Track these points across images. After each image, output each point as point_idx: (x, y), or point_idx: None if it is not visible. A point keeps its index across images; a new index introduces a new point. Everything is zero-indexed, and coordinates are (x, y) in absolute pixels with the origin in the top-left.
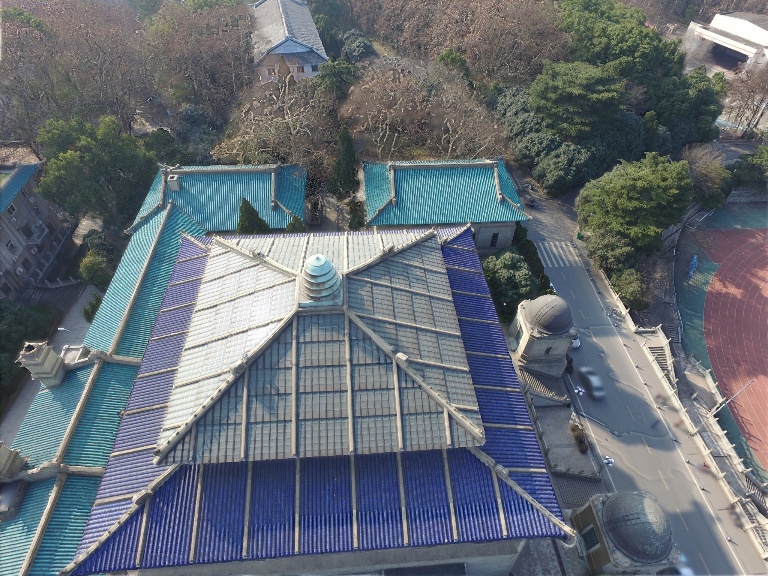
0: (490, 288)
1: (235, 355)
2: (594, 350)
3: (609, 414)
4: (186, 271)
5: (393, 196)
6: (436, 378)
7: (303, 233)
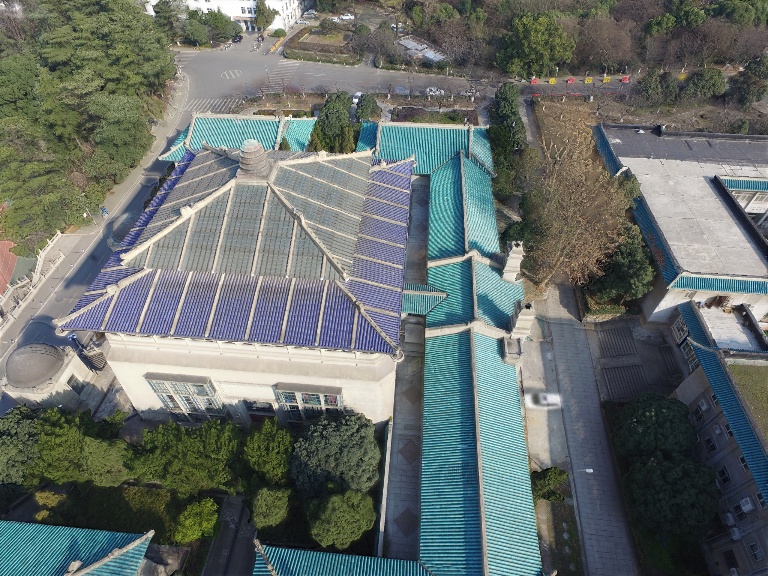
0: (62, 414)
1: (325, 170)
2: (1, 406)
3: (60, 344)
4: (385, 298)
5: (69, 574)
6: (209, 159)
7: (257, 340)
